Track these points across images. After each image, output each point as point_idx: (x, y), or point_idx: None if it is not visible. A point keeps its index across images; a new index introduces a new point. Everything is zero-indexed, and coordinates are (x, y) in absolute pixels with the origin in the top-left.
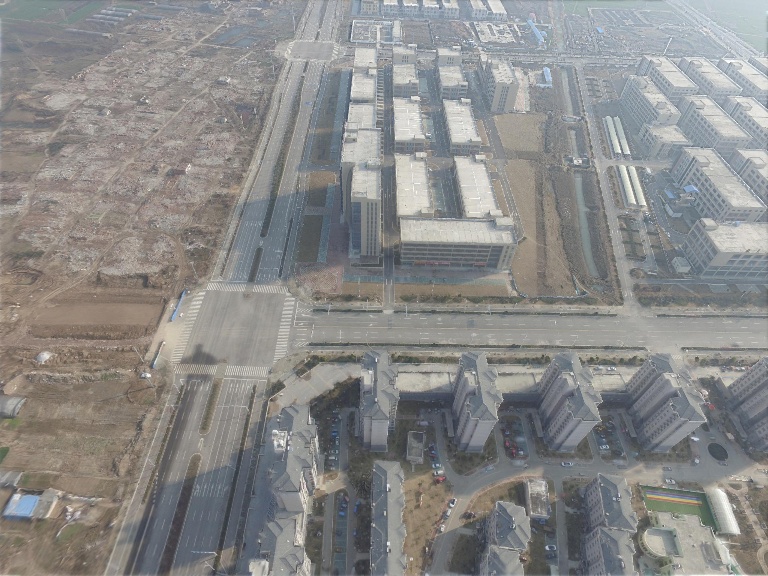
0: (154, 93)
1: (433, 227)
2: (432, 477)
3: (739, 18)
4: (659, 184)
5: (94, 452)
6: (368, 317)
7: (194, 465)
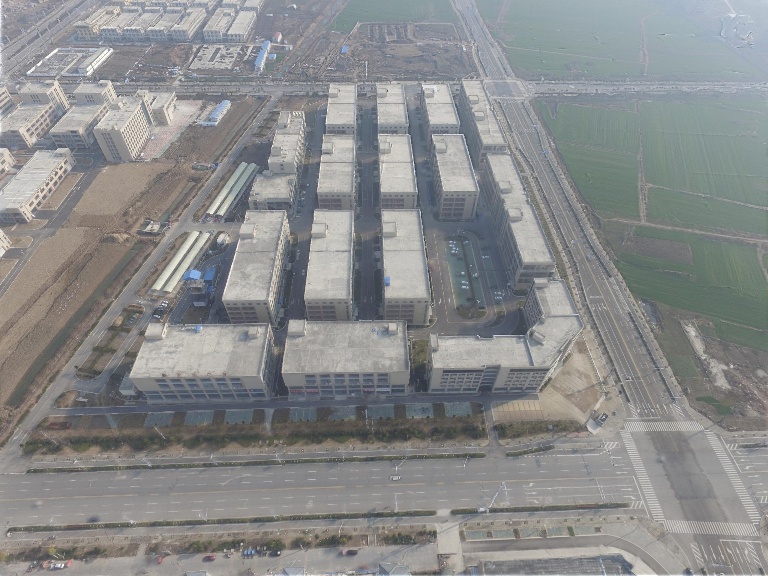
0: None
1: None
2: None
3: (527, 28)
4: (225, 256)
5: None
6: None
7: None
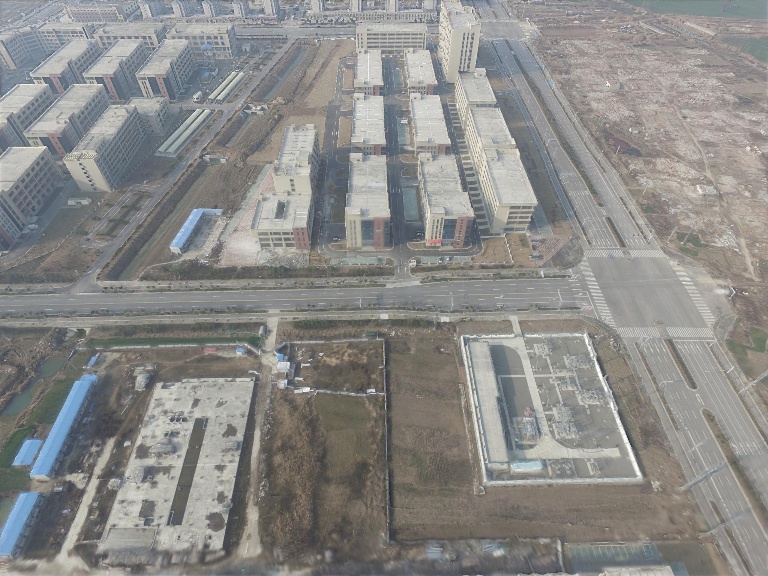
0: (762, 163)
1: (407, 29)
2: (406, 6)
3: None
4: None
5: (528, 8)
6: (438, 32)
7: (490, 6)
